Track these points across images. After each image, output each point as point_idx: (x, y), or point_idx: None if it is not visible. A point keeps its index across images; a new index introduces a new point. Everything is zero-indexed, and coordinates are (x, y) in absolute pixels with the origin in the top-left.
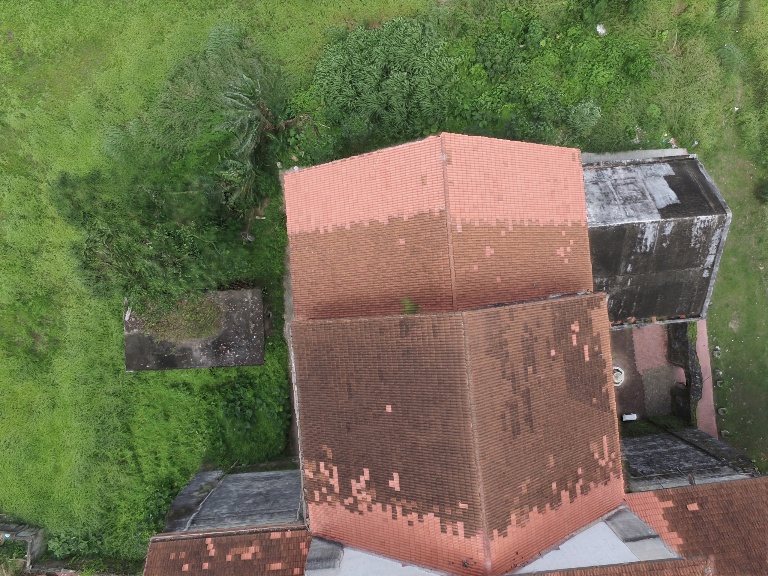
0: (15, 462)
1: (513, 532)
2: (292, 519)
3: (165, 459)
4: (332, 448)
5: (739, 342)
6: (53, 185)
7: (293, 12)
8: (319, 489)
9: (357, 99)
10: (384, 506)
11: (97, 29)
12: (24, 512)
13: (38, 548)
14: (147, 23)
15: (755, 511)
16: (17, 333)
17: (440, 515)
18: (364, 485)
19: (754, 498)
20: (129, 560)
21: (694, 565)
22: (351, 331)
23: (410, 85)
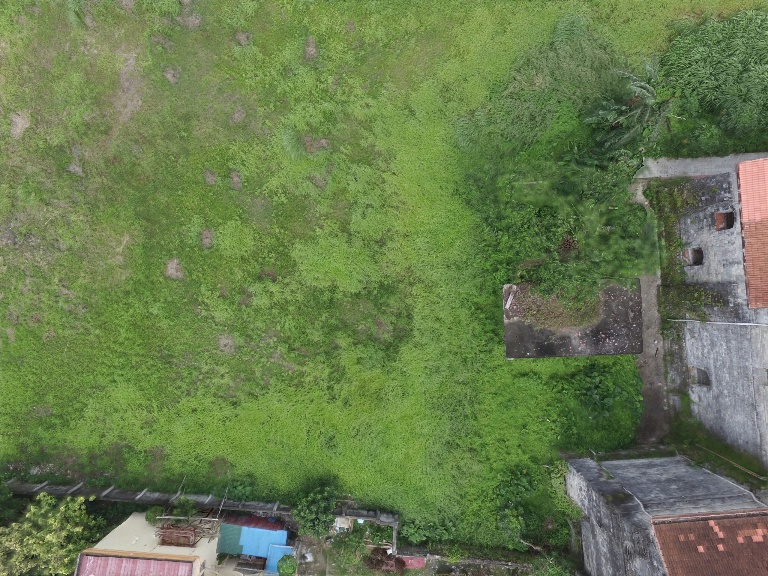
0: (366, 449)
1: None
2: (752, 504)
3: (515, 447)
4: None
5: None
6: (398, 174)
7: (635, 4)
8: None
9: (717, 91)
10: None
11: (438, 20)
12: (377, 498)
13: None
14: (488, 14)
15: None
16: (360, 321)
17: None
18: None
19: None
20: (485, 546)
21: None
22: None
23: (767, 77)
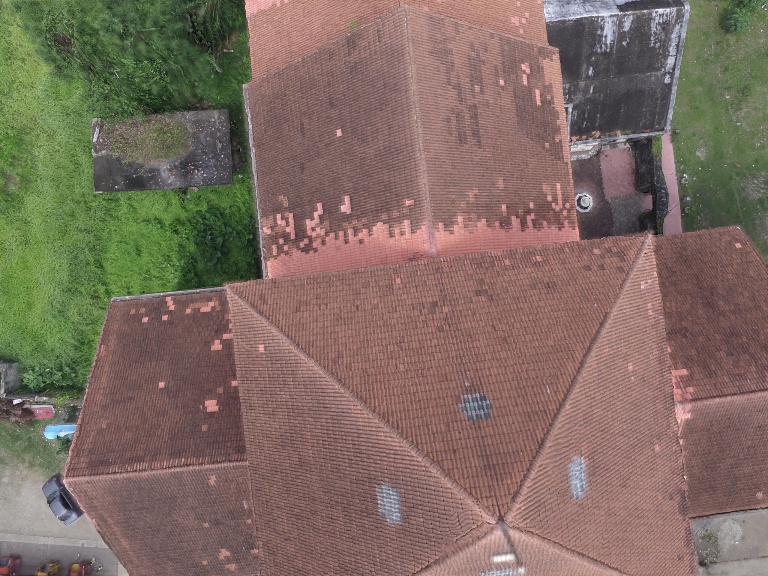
0: None
1: (460, 234)
2: None
3: None
4: (288, 195)
5: (706, 170)
6: (23, 26)
7: None
8: (277, 242)
9: None
10: (337, 234)
11: None
12: None
13: (12, 381)
14: None
15: (708, 254)
16: None
17: (388, 221)
18: (318, 220)
19: (708, 244)
20: None
21: (635, 238)
22: (303, 68)
23: None
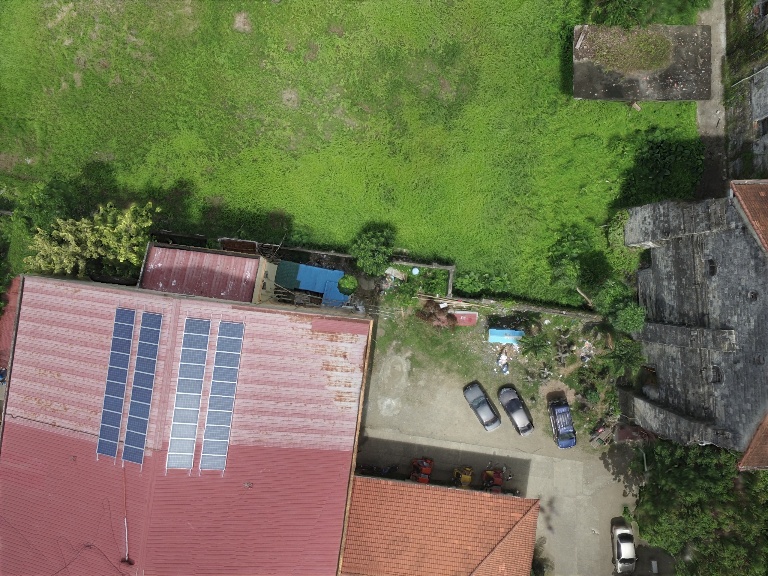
0: (424, 202)
1: None
2: None
3: (573, 207)
4: None
5: None
6: None
7: None
8: None
9: None
10: None
11: None
12: (434, 249)
13: None
14: None
15: None
16: (424, 81)
17: None
18: None
19: None
20: (539, 300)
21: None
22: None
23: None
